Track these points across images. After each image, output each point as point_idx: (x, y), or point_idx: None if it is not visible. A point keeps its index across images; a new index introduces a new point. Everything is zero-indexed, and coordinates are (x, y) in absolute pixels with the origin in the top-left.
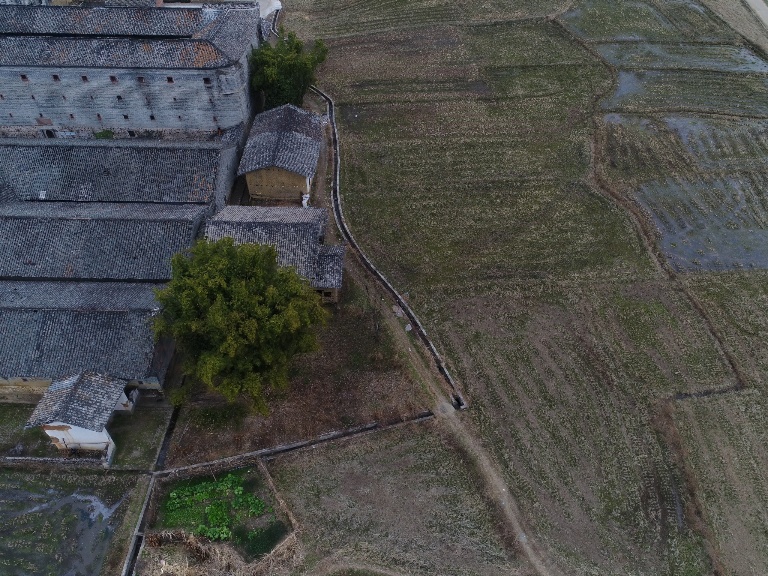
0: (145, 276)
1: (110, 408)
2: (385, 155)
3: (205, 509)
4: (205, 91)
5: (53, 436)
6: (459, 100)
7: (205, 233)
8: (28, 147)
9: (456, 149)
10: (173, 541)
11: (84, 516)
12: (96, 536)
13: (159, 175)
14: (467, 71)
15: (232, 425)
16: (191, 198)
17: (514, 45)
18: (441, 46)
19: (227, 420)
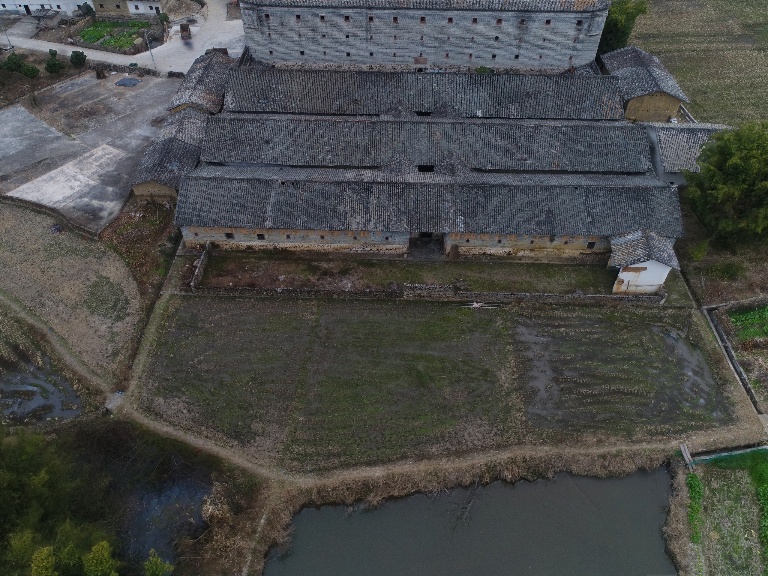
0: (620, 169)
1: (673, 255)
2: (707, 91)
3: (764, 329)
4: (573, 32)
5: (622, 278)
6: (738, 50)
7: (658, 137)
8: (456, 75)
9: (764, 87)
10: (762, 346)
11: (667, 335)
12: (687, 347)
13: (573, 97)
14: (728, 27)
15: (742, 276)
16: (605, 116)
17: (753, 6)
18: (690, 7)
19: (736, 273)
